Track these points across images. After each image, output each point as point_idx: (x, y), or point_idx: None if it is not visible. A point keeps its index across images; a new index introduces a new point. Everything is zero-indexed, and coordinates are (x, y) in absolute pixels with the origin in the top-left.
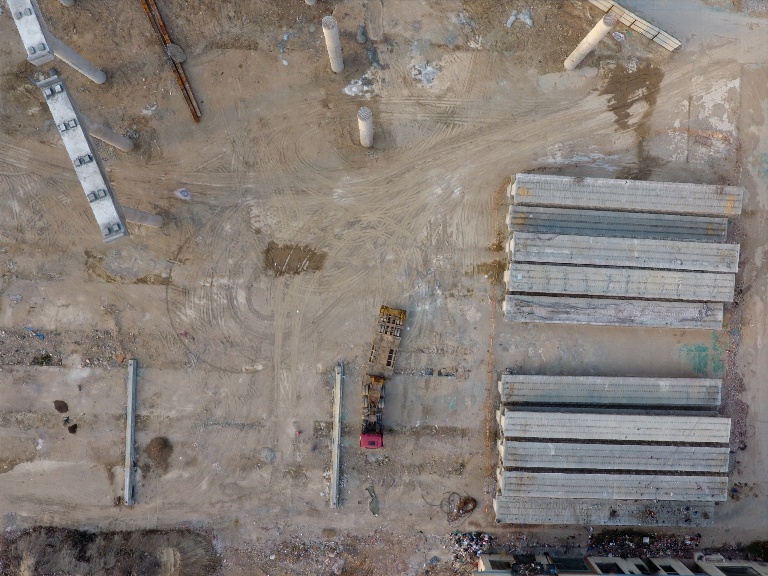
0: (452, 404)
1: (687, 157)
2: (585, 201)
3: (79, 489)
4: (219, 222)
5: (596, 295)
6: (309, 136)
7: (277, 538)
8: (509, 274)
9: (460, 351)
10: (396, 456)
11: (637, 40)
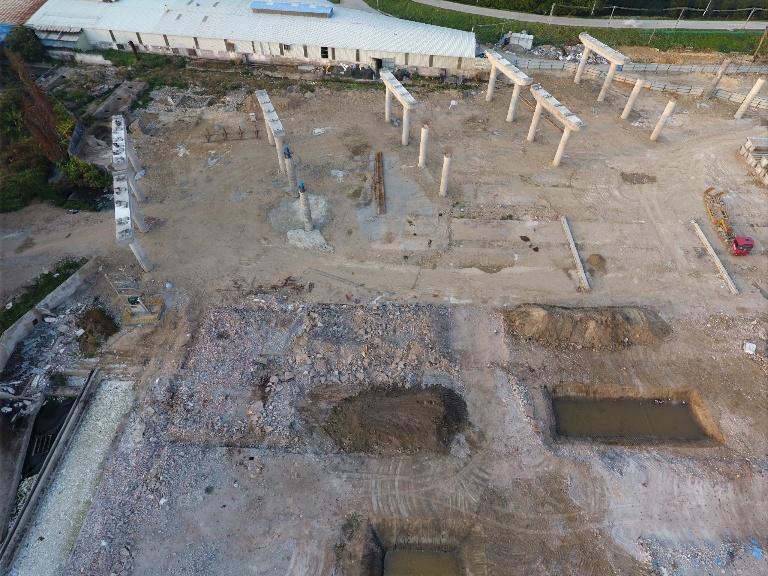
0: None
1: None
2: None
3: (549, 282)
4: (589, 165)
5: None
6: None
7: (705, 313)
8: None
9: (763, 216)
10: (760, 266)
11: (764, 111)
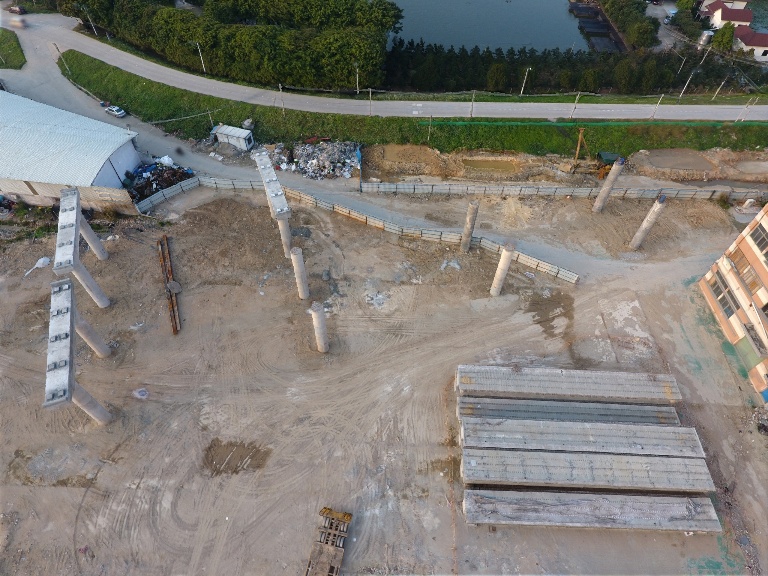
0: None
1: (616, 358)
2: (527, 388)
3: None
4: (167, 419)
5: (564, 489)
6: (272, 344)
7: None
8: (462, 461)
9: (417, 571)
10: None
11: (545, 277)
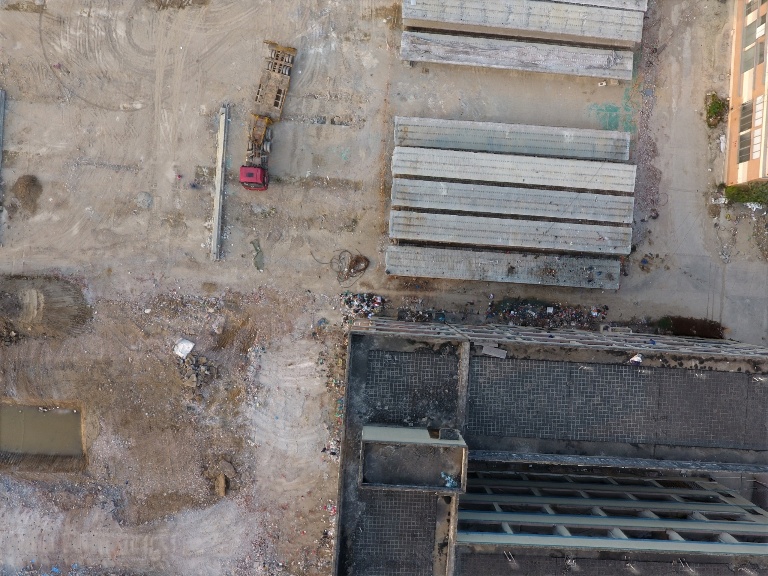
0: (345, 155)
1: None
2: None
3: None
4: None
5: (498, 36)
6: None
7: (153, 290)
8: None
9: (355, 99)
10: (284, 208)
11: None
